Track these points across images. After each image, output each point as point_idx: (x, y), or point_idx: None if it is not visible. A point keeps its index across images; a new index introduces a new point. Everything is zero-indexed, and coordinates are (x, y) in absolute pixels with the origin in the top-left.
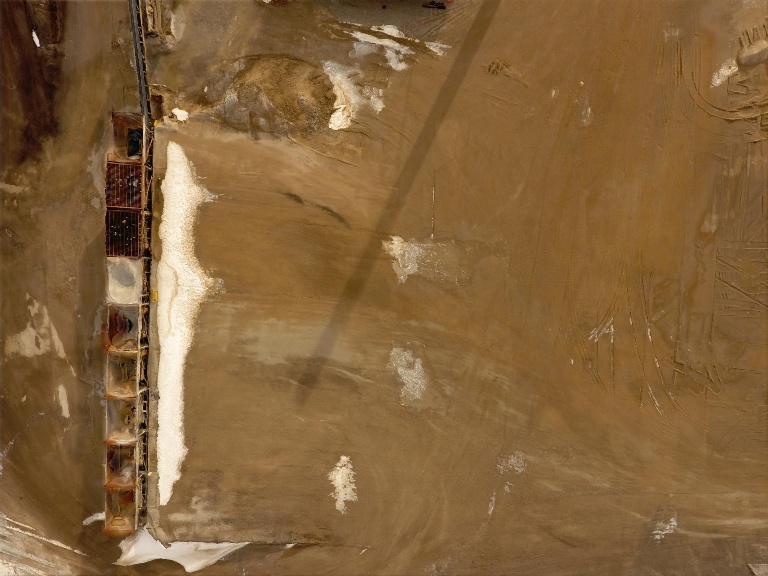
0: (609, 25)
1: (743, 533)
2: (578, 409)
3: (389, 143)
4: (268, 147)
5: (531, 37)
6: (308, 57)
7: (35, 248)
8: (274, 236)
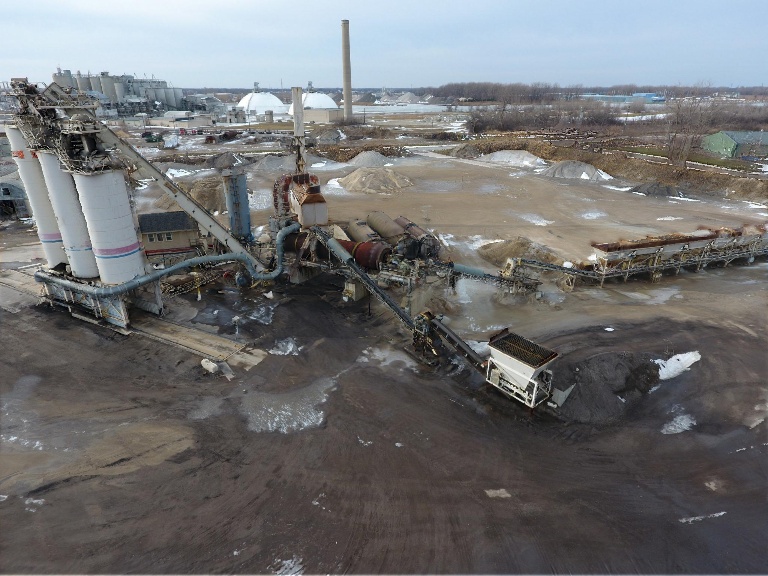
0: (384, 207)
1: (543, 178)
2: (547, 195)
3: (493, 231)
4: (545, 243)
5: (404, 216)
6: (475, 253)
7: (762, 311)
8: (588, 236)
